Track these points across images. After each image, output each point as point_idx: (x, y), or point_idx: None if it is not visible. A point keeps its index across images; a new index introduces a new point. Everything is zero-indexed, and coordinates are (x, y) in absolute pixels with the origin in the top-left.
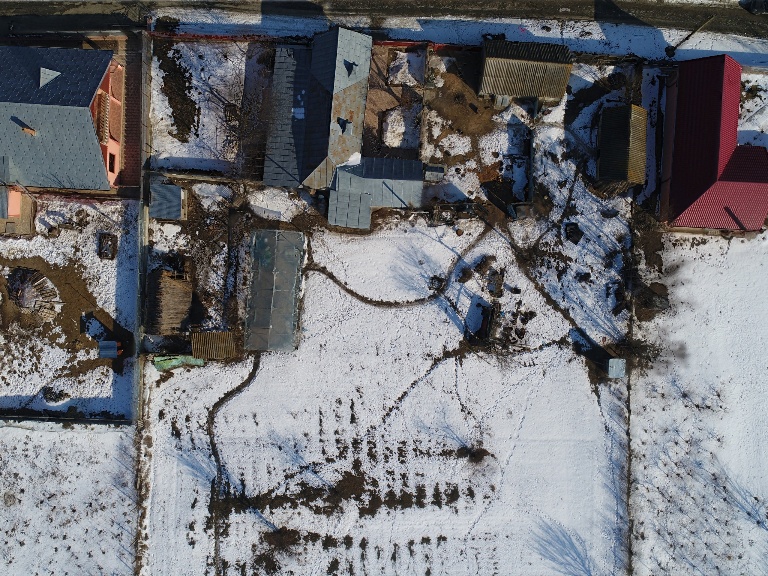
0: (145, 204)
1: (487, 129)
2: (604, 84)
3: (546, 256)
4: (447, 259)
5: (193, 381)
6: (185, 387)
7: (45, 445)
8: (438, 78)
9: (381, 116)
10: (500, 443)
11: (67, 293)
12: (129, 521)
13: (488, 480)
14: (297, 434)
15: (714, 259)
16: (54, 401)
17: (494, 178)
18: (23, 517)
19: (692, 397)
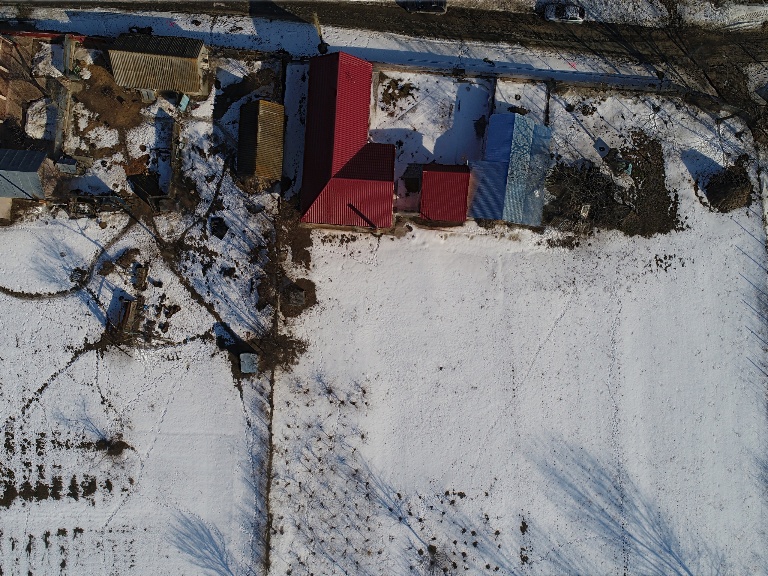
0: None
1: (135, 122)
2: (253, 79)
3: (191, 250)
4: (90, 252)
5: None
6: None
7: None
8: (84, 70)
9: (25, 107)
10: (140, 436)
11: None
12: None
13: (127, 473)
14: None
15: (363, 256)
16: None
17: (141, 171)
18: None
19: (337, 393)
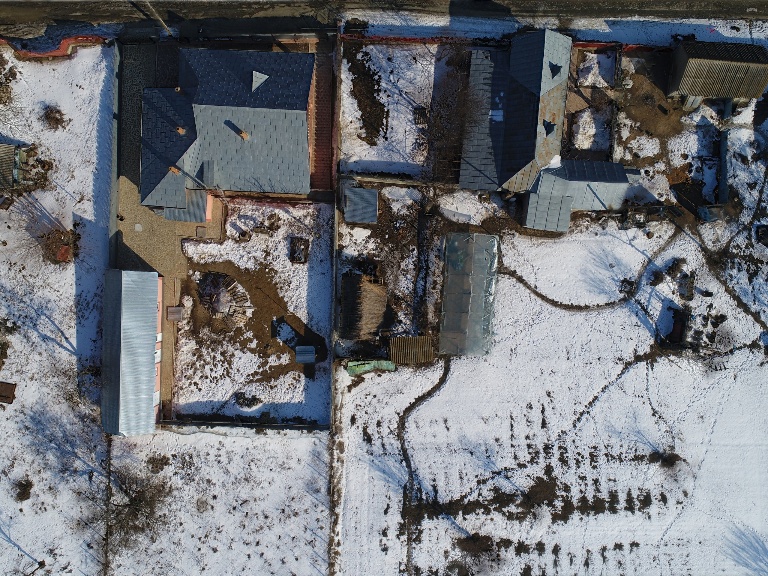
0: (337, 208)
1: (676, 131)
2: None
3: (737, 259)
4: (637, 262)
5: (384, 386)
6: (376, 392)
7: (238, 451)
8: (627, 79)
9: (570, 118)
10: (692, 448)
11: (258, 298)
12: (322, 527)
13: (680, 485)
14: (488, 439)
15: None
16: (248, 406)
17: (683, 180)
18: (216, 523)
19: None
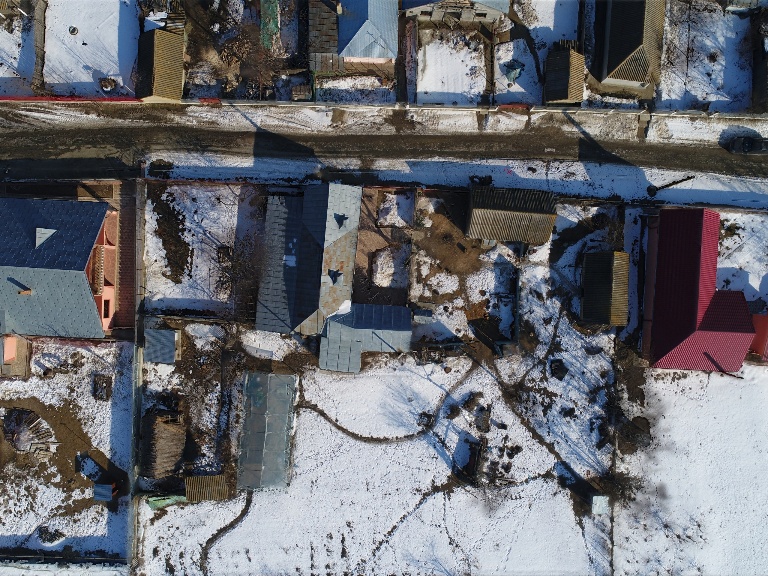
0: (139, 346)
1: (474, 268)
2: (588, 224)
3: (532, 392)
4: (435, 396)
5: (187, 518)
6: (179, 524)
7: None
8: (426, 219)
9: (371, 256)
10: (487, 575)
11: (62, 433)
12: None
13: None
14: (289, 569)
15: (694, 392)
16: (49, 542)
17: (481, 316)
18: None
19: (673, 527)
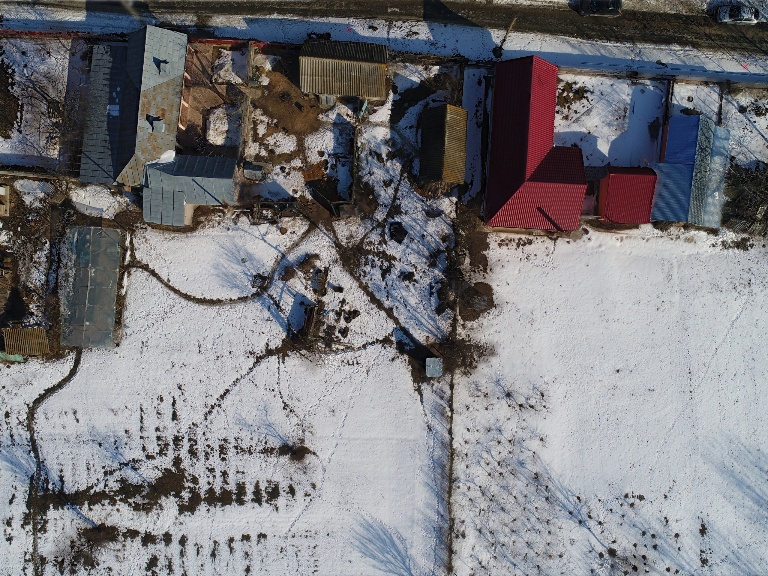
0: None
1: (313, 128)
2: (430, 84)
3: (370, 255)
4: (270, 257)
5: (13, 377)
6: (5, 383)
7: None
8: (263, 76)
9: (205, 114)
10: (322, 441)
11: None
12: None
13: (309, 478)
14: (117, 431)
15: (540, 259)
16: None
17: (319, 177)
18: None
19: (516, 397)
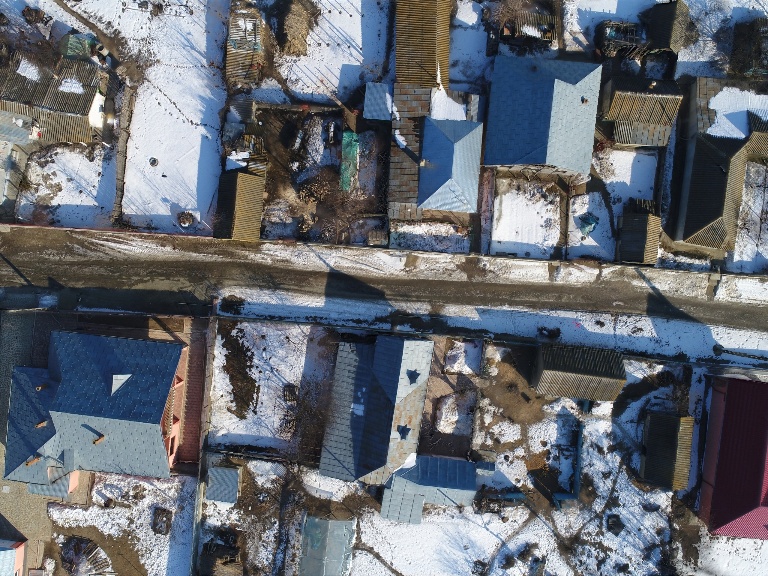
0: (201, 481)
1: (537, 418)
2: (653, 380)
3: (587, 545)
4: (491, 545)
5: None
6: None
7: None
8: (493, 367)
9: (435, 402)
10: None
11: (119, 563)
12: None
13: None
14: None
15: (748, 553)
16: None
17: (541, 466)
18: None
19: None
